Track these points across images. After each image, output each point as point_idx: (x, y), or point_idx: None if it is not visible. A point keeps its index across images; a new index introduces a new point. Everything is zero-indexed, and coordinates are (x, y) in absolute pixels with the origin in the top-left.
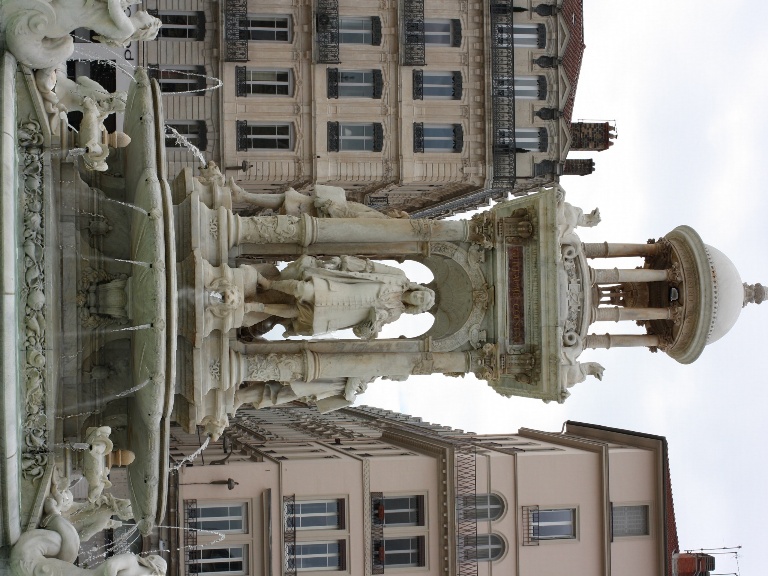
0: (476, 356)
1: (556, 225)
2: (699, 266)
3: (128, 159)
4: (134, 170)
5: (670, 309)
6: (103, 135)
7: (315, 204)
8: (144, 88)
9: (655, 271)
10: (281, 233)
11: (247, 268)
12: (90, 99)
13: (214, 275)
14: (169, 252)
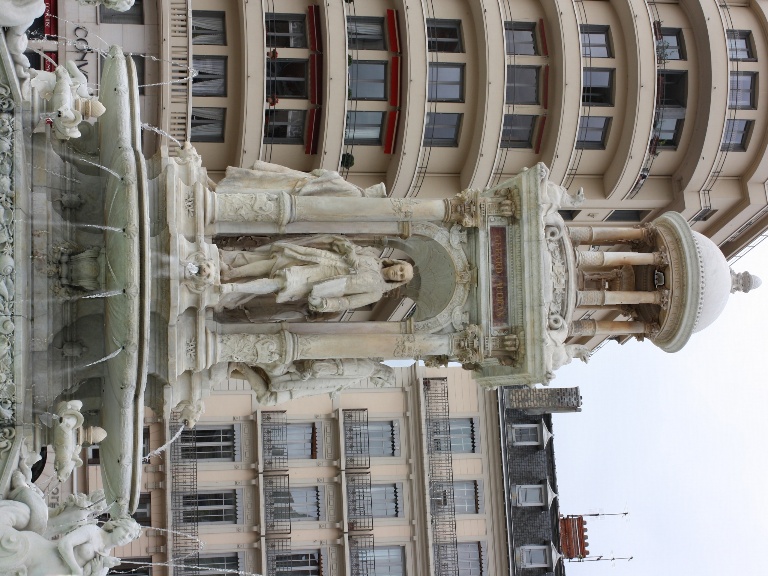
0: (424, 359)
1: (532, 384)
2: (675, 341)
3: (107, 349)
4: (111, 380)
5: (632, 334)
6: (78, 443)
7: (308, 300)
8: (129, 357)
9: (633, 331)
10: (258, 362)
11: (217, 380)
12: (66, 423)
13: (182, 399)
14: (132, 507)
